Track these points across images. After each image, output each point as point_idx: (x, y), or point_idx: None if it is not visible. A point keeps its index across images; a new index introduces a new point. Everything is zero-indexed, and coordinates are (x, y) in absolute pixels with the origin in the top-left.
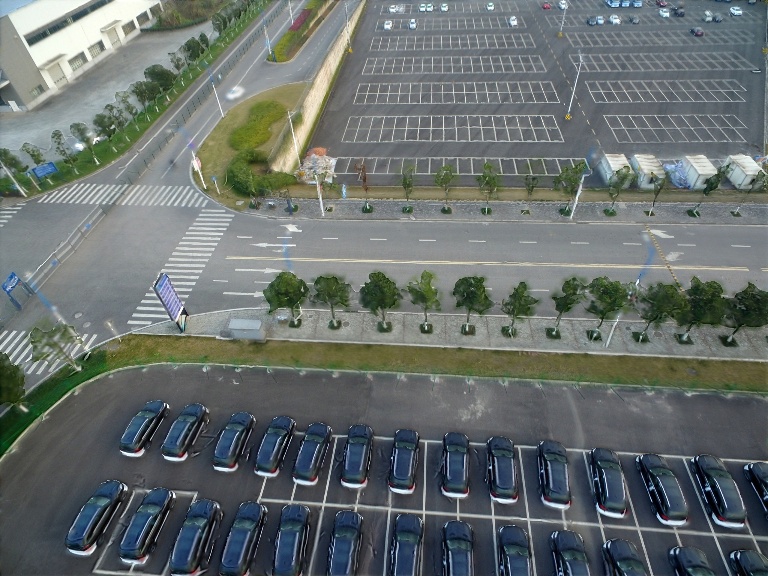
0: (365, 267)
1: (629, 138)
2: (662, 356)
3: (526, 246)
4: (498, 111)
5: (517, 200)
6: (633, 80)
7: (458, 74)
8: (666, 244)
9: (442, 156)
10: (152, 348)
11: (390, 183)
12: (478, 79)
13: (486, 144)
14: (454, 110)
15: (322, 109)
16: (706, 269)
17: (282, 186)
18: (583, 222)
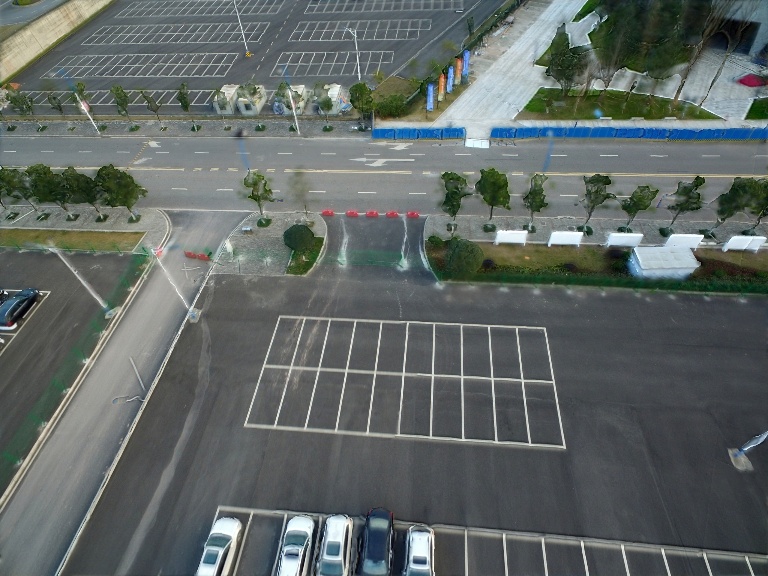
0: None
1: (282, 72)
2: (41, 229)
3: (42, 155)
4: (197, 50)
5: (74, 120)
6: (342, 20)
7: (198, 16)
8: (148, 152)
9: (109, 89)
10: None
11: (45, 112)
12: (209, 21)
13: (156, 79)
14: (160, 49)
15: (48, 49)
16: (152, 169)
17: None
18: (106, 136)
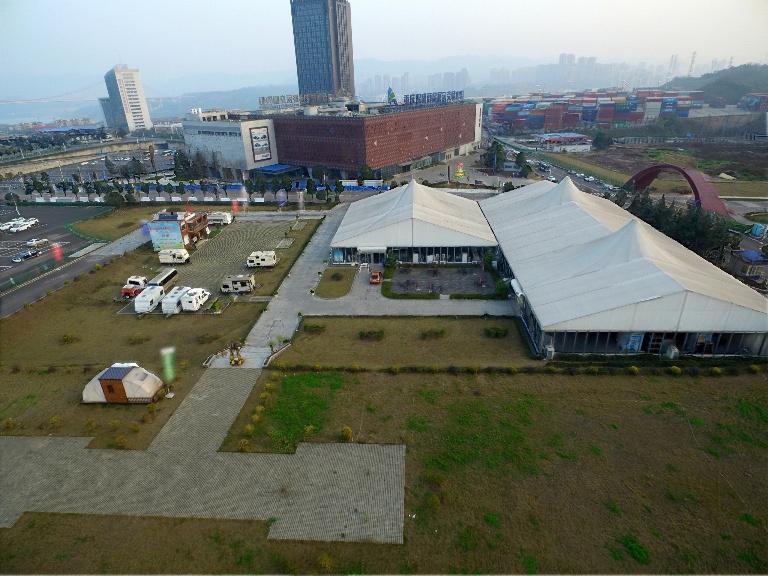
0: None
1: None
2: None
3: None
4: None
5: None
6: None
7: None
8: None
9: None
10: None
11: None
12: None
13: None
14: None
15: None
16: None
17: None
18: None
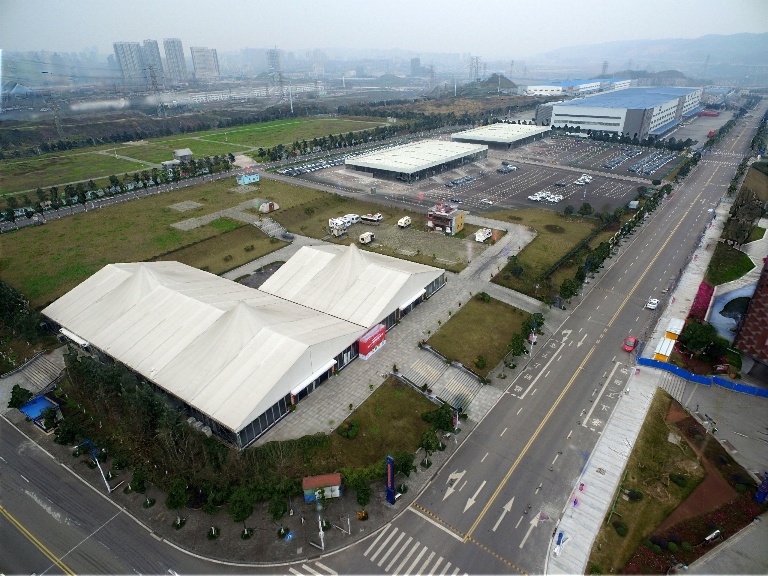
0: (714, 169)
1: None
2: None
3: None
4: None
5: None
6: None
7: None
8: None
9: None
10: (690, 159)
11: None
12: None
13: None
14: None
15: None
16: None
17: (762, 172)
18: None
